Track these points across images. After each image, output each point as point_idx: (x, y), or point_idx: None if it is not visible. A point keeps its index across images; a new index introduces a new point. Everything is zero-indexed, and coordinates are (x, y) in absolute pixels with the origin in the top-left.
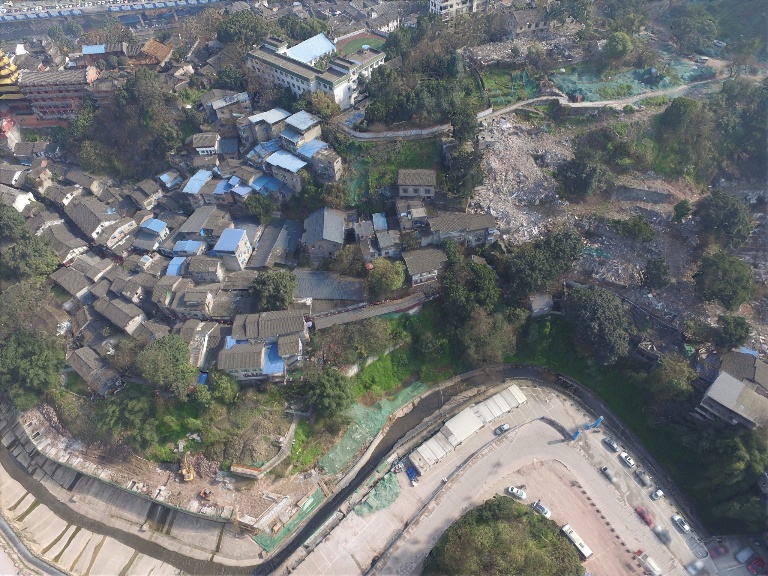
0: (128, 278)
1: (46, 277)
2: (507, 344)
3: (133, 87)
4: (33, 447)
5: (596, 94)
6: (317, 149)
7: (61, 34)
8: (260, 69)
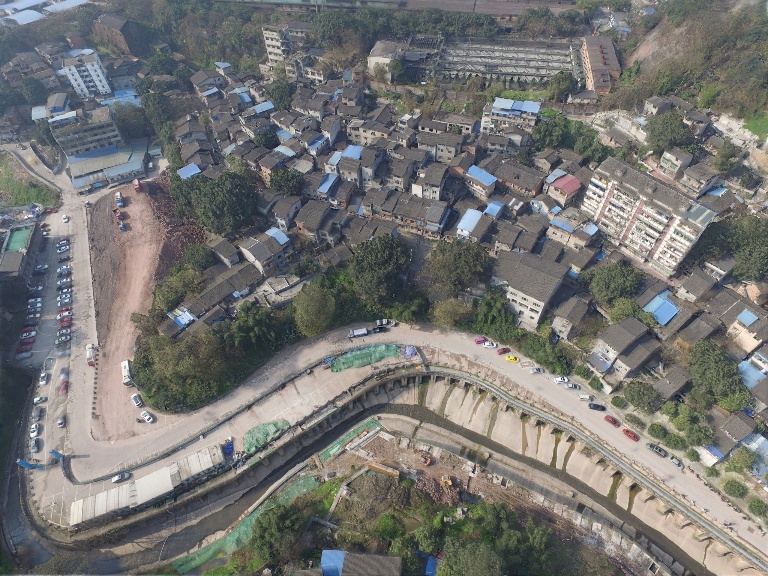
0: None
1: None
2: None
3: None
4: None
5: None
6: None
7: None
8: None
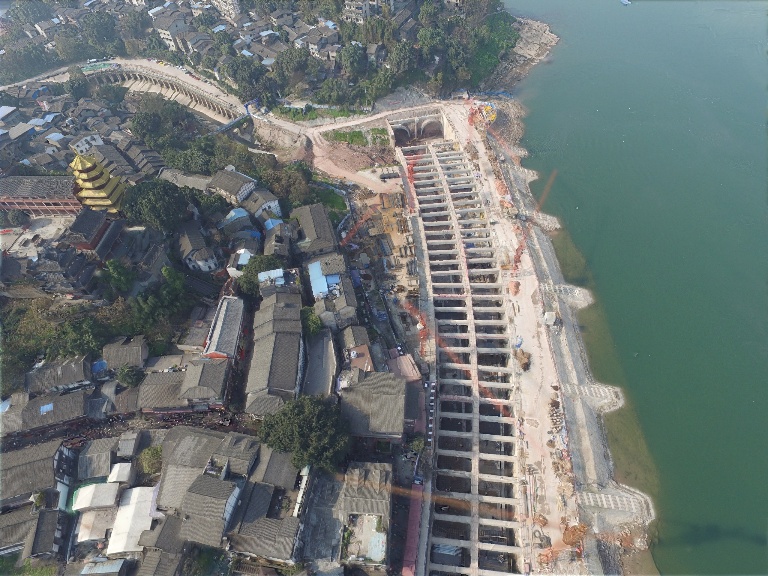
0: (89, 120)
1: None
2: None
3: None
4: None
5: None
6: None
7: None
8: None
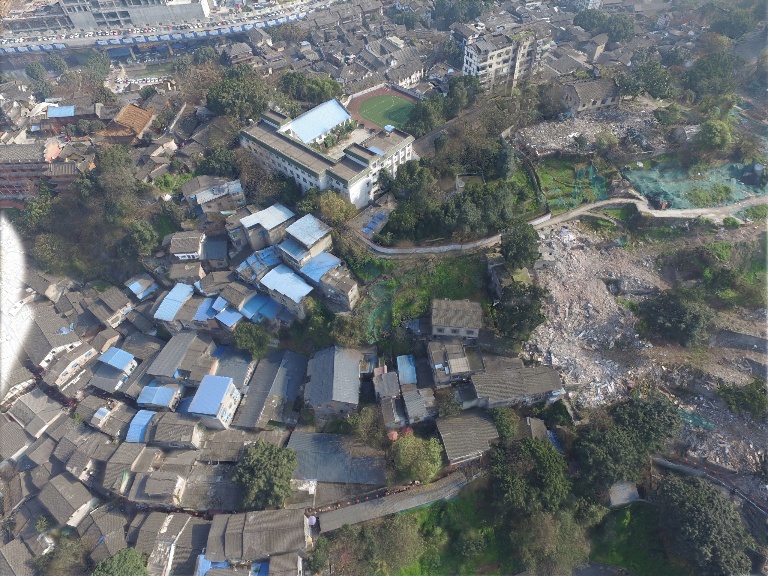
0: (78, 439)
1: None
2: (578, 555)
3: (98, 175)
4: None
5: (685, 199)
6: (326, 269)
7: (41, 72)
8: (257, 151)
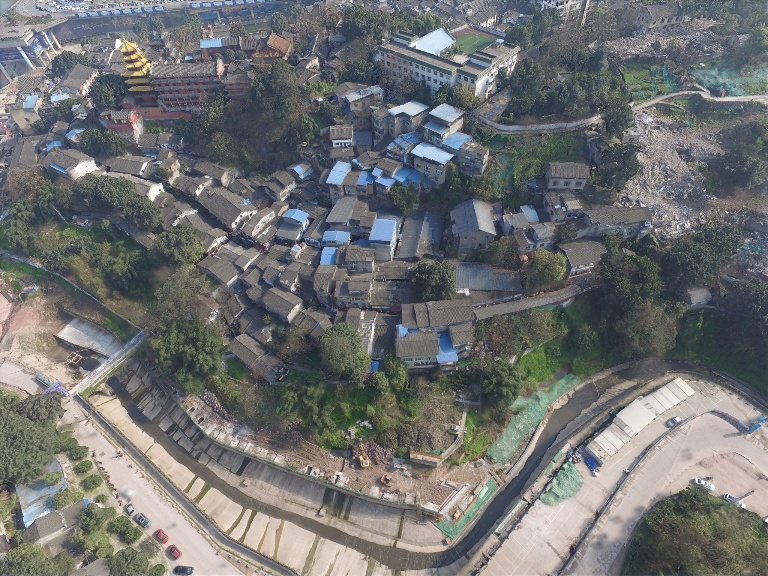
0: (280, 267)
1: (193, 265)
2: (668, 337)
3: (270, 79)
4: (194, 432)
5: (740, 89)
6: (463, 141)
7: (145, 30)
8: (391, 63)
